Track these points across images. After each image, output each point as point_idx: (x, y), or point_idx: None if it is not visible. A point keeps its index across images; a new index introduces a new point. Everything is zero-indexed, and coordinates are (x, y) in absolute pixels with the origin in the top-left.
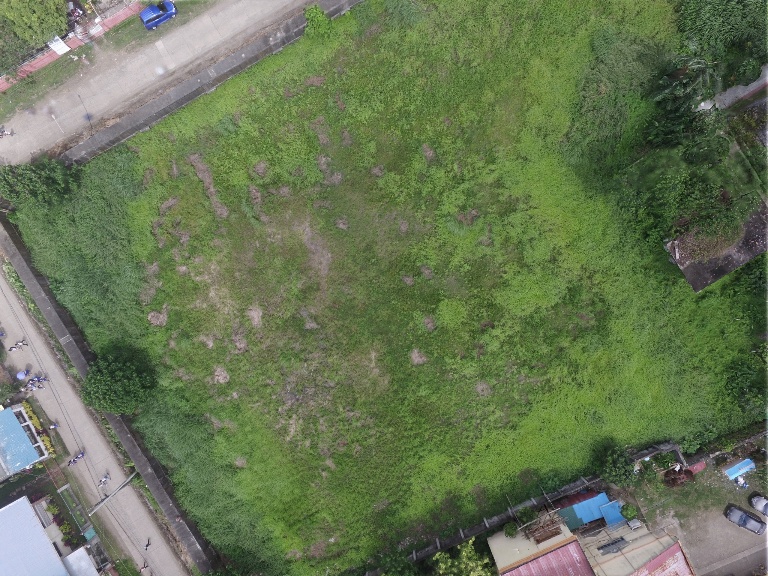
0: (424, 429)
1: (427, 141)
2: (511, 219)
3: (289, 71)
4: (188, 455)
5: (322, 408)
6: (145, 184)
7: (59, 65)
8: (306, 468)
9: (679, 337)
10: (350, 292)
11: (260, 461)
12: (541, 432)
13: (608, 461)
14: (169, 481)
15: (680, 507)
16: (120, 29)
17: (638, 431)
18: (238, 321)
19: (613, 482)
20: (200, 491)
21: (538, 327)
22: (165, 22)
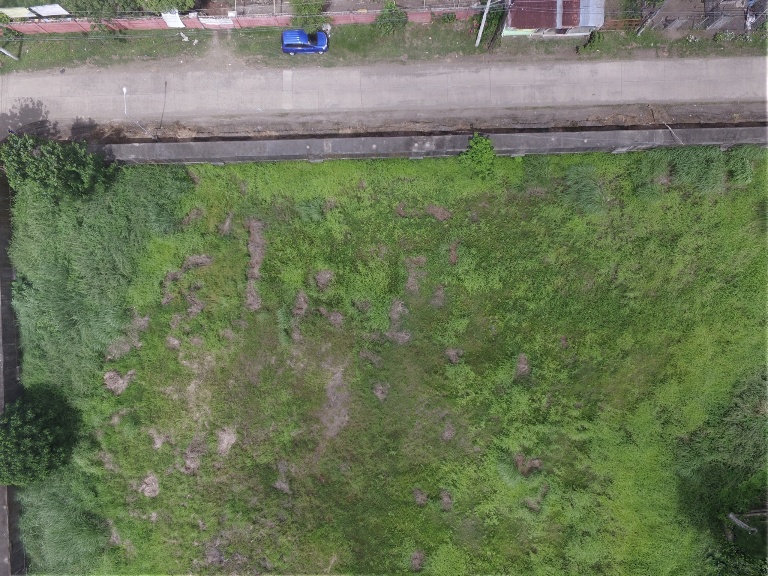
0: None
1: (528, 352)
2: (575, 496)
3: (416, 187)
4: (61, 562)
5: None
6: (184, 225)
7: (162, 37)
8: None
9: None
10: (347, 474)
11: None
12: None
13: None
14: None
15: None
16: (253, 34)
17: None
18: (203, 435)
19: None
20: None
21: None
22: (308, 53)
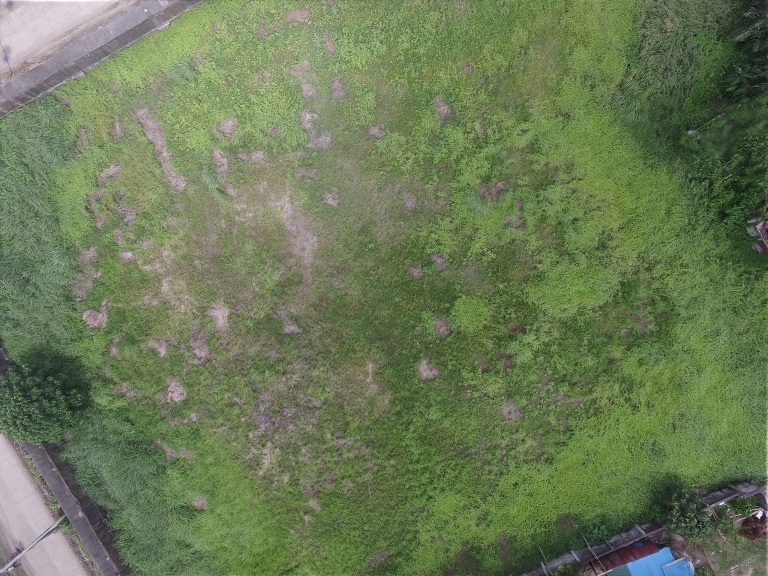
0: (434, 462)
1: (441, 93)
2: (548, 194)
3: (264, 2)
4: (131, 494)
5: (304, 434)
6: (79, 146)
7: None
8: (284, 510)
9: (764, 347)
10: (341, 286)
11: (225, 501)
12: (584, 467)
13: (674, 508)
14: (107, 527)
15: (761, 564)
16: None
17: (710, 467)
18: (198, 322)
19: (681, 535)
20: (147, 541)
21: (582, 333)
22: None
